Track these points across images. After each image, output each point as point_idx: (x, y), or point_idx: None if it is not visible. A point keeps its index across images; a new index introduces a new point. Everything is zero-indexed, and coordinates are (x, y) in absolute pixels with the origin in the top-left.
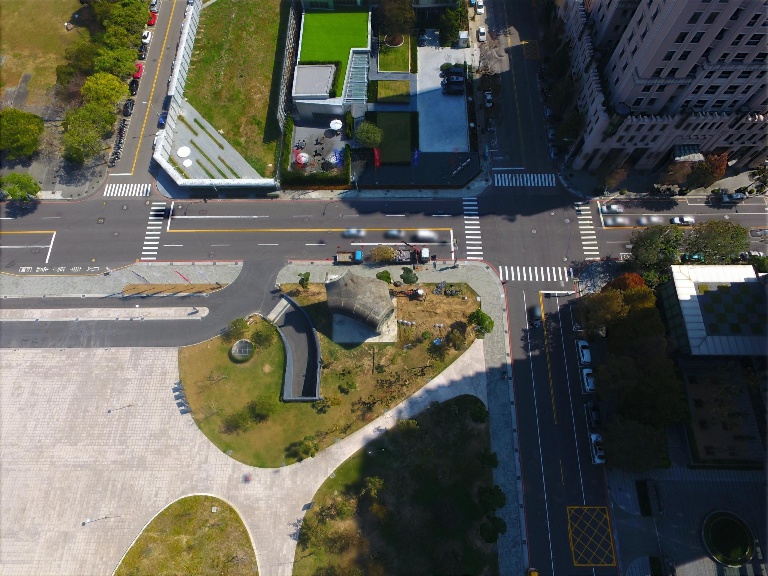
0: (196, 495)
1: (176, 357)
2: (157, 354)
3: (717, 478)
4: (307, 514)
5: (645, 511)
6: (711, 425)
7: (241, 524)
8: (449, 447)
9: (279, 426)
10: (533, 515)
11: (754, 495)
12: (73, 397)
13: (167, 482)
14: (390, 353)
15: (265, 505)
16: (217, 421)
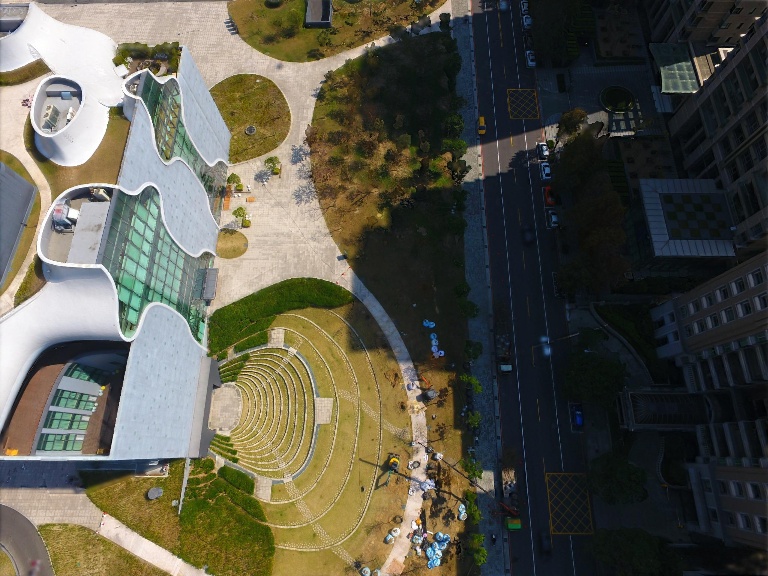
0: (245, 73)
1: (226, 6)
2: (212, 5)
3: (613, 70)
4: (323, 85)
5: (562, 89)
6: (610, 33)
7: (277, 88)
8: (425, 57)
9: (303, 40)
10: (483, 94)
11: (638, 77)
12: (152, 27)
13: (223, 68)
14: (383, 6)
15: (294, 80)
16: (258, 38)
